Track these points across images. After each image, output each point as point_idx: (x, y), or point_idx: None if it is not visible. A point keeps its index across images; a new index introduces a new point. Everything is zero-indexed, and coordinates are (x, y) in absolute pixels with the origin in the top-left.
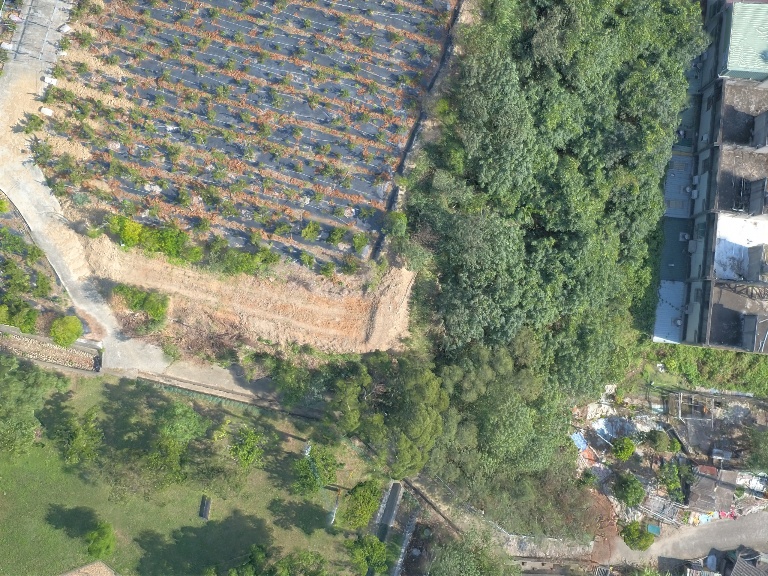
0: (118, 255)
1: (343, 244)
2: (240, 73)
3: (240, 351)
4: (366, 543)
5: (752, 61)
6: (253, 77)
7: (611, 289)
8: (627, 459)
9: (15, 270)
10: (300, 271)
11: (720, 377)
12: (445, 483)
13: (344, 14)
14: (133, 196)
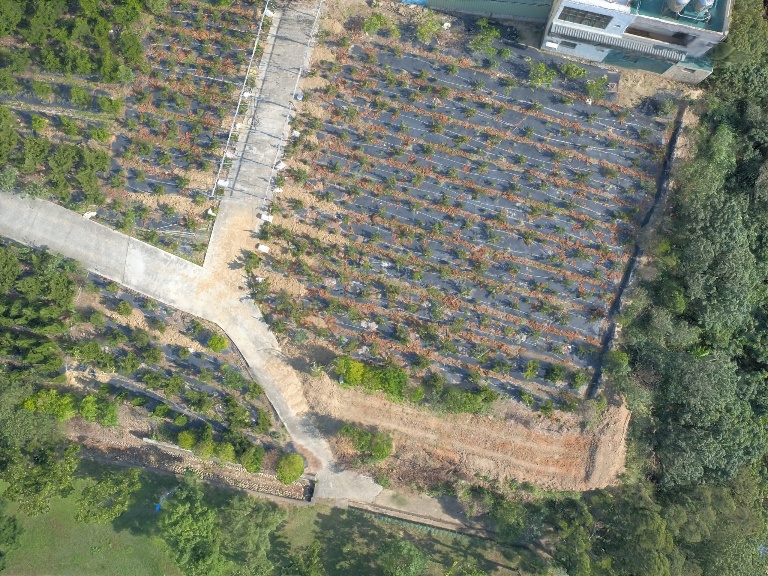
0: (336, 392)
1: (560, 381)
2: (454, 209)
3: (458, 487)
4: None
5: None
6: (467, 213)
7: None
8: None
9: (237, 408)
10: (517, 408)
11: None
12: None
13: (558, 149)
14: (349, 332)
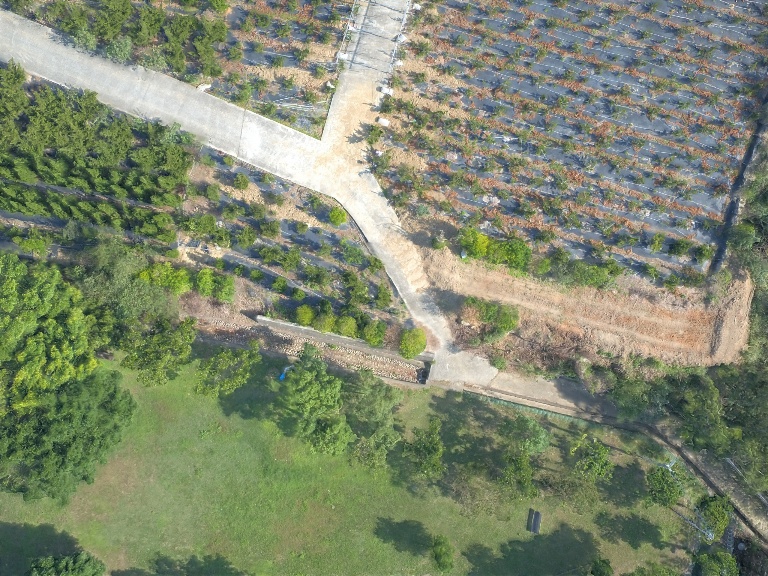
0: (458, 267)
1: (684, 257)
2: (576, 84)
3: (581, 364)
4: (720, 559)
5: None
6: (589, 88)
7: None
8: None
9: (358, 282)
10: (641, 284)
11: None
12: None
13: (680, 26)
14: (470, 207)
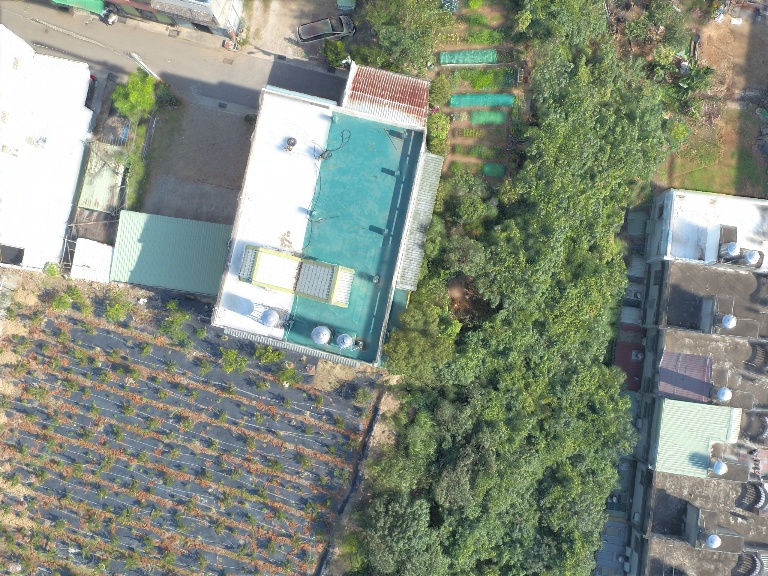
0: None
1: None
2: (145, 493)
3: None
4: None
5: (682, 460)
6: (158, 497)
7: None
8: None
9: None
10: None
11: None
12: None
13: (253, 432)
14: None
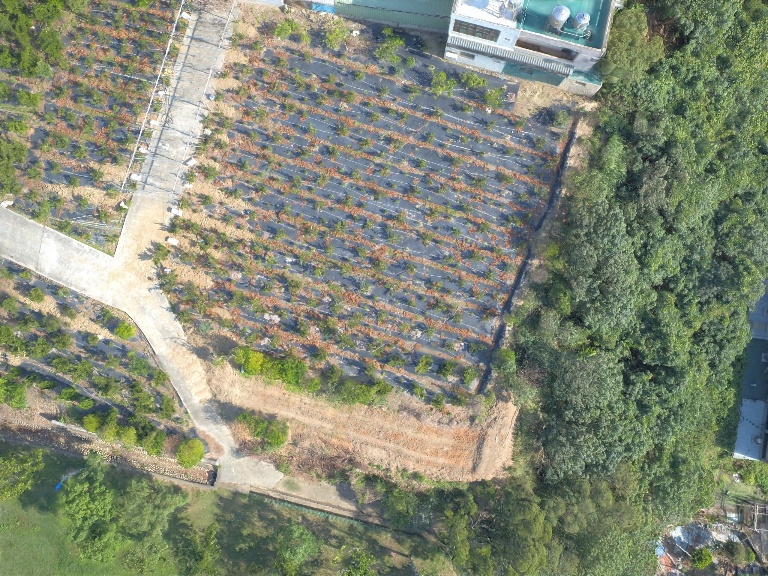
0: (238, 381)
1: (452, 376)
2: (357, 209)
3: (351, 475)
4: None
5: None
6: (369, 213)
7: (701, 417)
8: (703, 568)
9: (142, 394)
10: (410, 401)
11: None
12: None
13: (457, 154)
14: (253, 324)
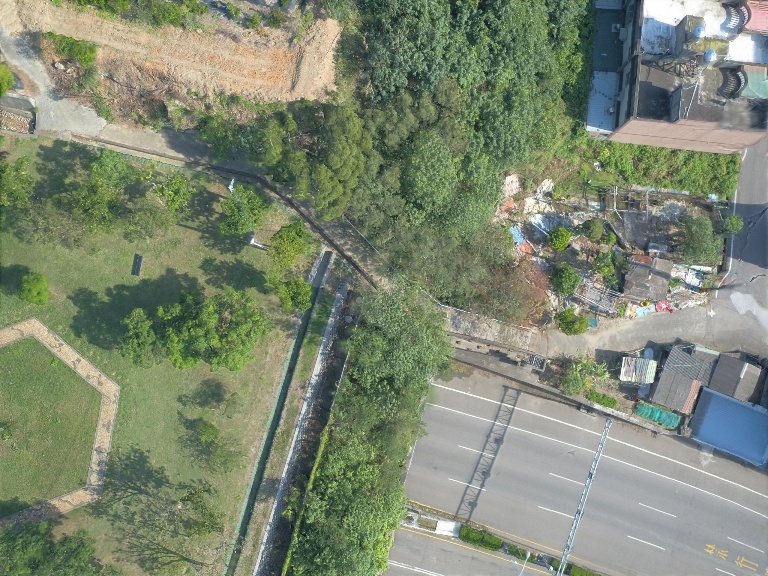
0: (49, 10)
1: None
2: None
3: (169, 103)
4: (290, 282)
5: None
6: None
7: (538, 58)
8: (563, 249)
9: None
10: (228, 25)
11: (655, 172)
12: (369, 227)
13: None
14: None
